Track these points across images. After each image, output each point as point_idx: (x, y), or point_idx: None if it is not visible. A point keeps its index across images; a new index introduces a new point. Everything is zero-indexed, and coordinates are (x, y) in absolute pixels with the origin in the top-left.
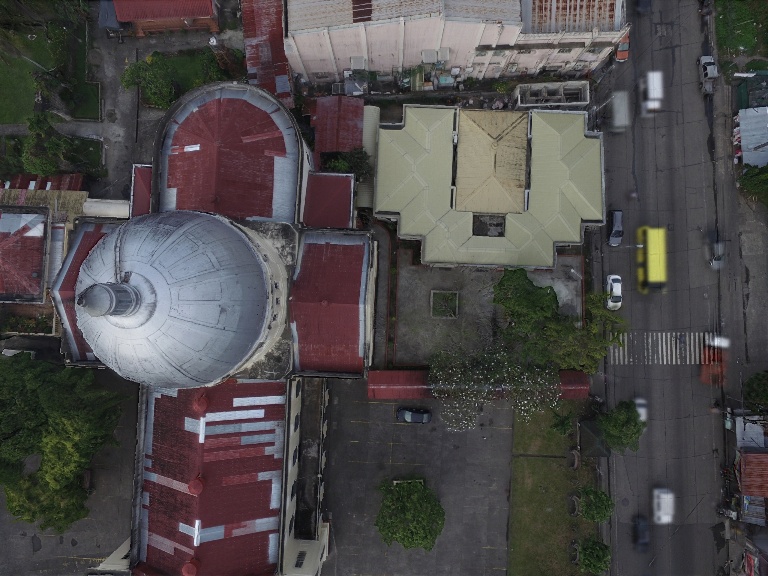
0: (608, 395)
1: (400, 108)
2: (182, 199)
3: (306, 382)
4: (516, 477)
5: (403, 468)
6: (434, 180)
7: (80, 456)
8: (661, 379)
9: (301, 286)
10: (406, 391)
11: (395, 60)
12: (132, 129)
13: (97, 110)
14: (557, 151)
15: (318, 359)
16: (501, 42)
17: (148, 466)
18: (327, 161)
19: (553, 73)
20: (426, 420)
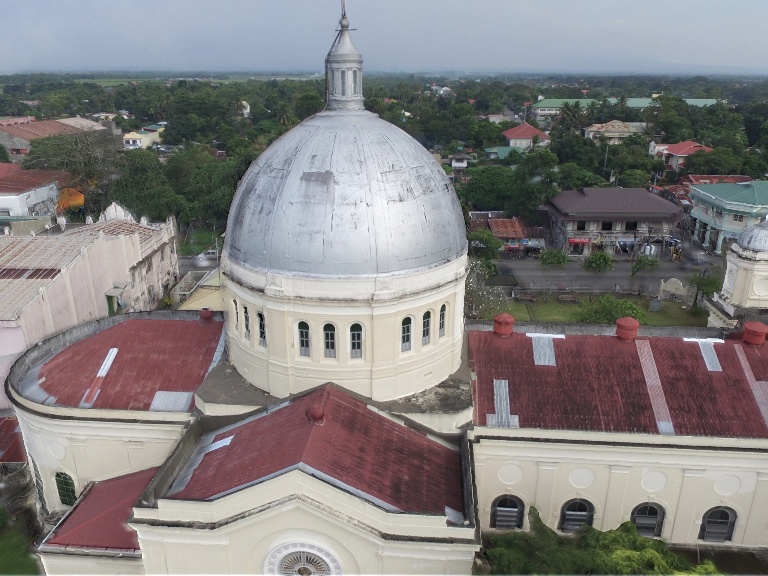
0: None
1: None
2: (181, 379)
3: None
4: None
5: None
6: None
7: None
8: None
9: None
10: None
11: None
12: None
13: None
14: None
15: None
16: None
17: None
18: None
19: None
20: None
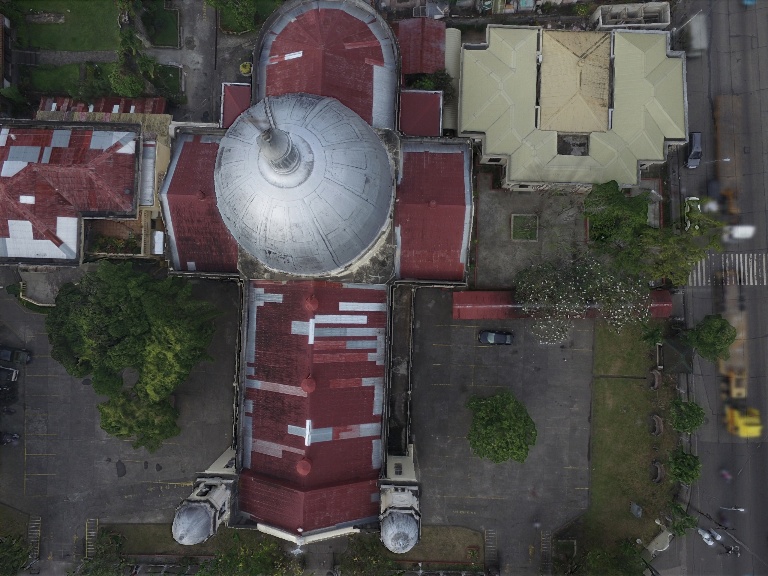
0: (687, 316)
1: (478, 34)
2: None
3: (395, 300)
4: (597, 398)
5: (485, 390)
6: (520, 99)
7: (180, 367)
8: (739, 299)
9: (406, 190)
10: (491, 311)
11: None
12: (211, 56)
13: (176, 37)
14: (641, 69)
15: (419, 266)
16: None
17: (251, 374)
18: (407, 86)
19: None
20: (509, 341)
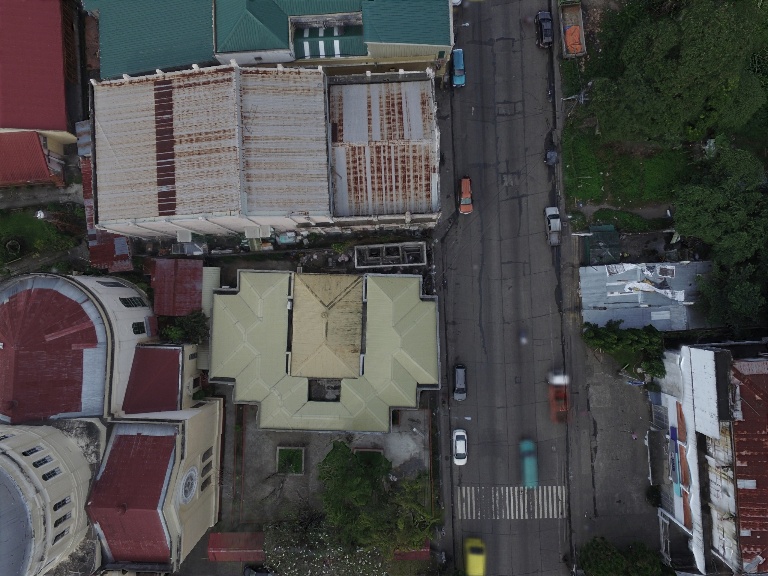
0: (456, 550)
1: (246, 262)
2: None
3: None
4: None
5: None
6: (267, 347)
7: None
8: (508, 534)
9: (103, 488)
10: (247, 554)
11: None
12: None
13: None
14: (390, 317)
15: (130, 552)
16: (320, 221)
17: None
18: None
19: None
20: None
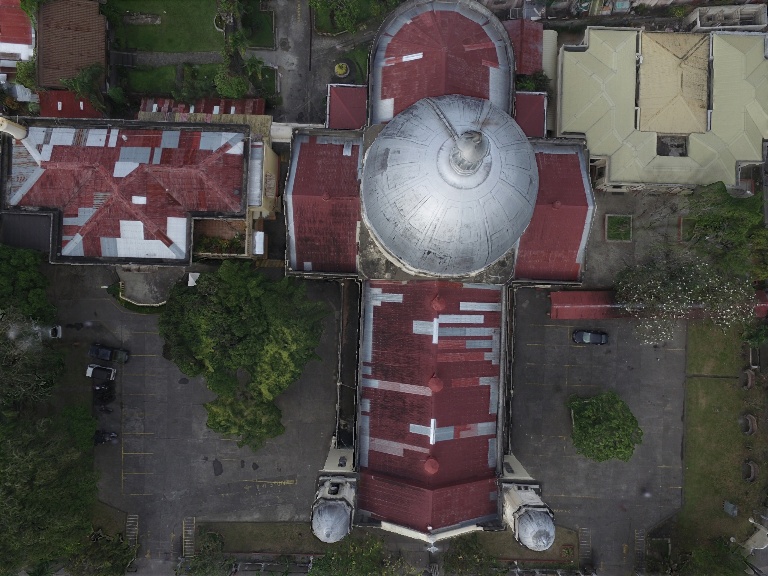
0: None
1: (571, 35)
2: (401, 108)
3: None
4: (690, 397)
5: (579, 389)
6: (620, 100)
7: (295, 366)
8: None
9: None
10: (589, 310)
11: None
12: (305, 57)
13: (271, 38)
14: (741, 71)
15: (534, 266)
16: None
17: (367, 373)
18: None
19: None
20: (604, 341)
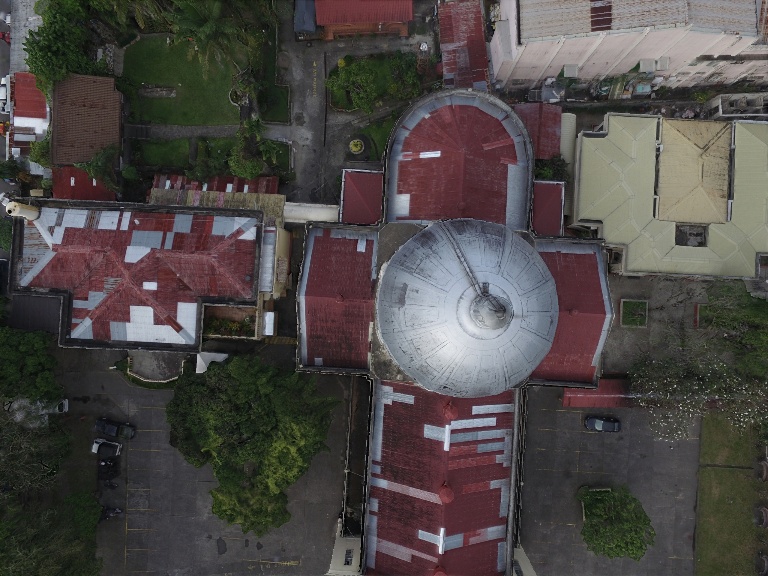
0: None
1: (590, 116)
2: (417, 205)
3: None
4: (703, 487)
5: (590, 476)
6: (639, 189)
7: (303, 461)
8: None
9: None
10: (602, 400)
11: (605, 68)
12: (320, 133)
13: (286, 113)
14: (764, 162)
15: (549, 368)
16: (724, 52)
17: (376, 472)
18: None
19: (748, 83)
20: (617, 429)
